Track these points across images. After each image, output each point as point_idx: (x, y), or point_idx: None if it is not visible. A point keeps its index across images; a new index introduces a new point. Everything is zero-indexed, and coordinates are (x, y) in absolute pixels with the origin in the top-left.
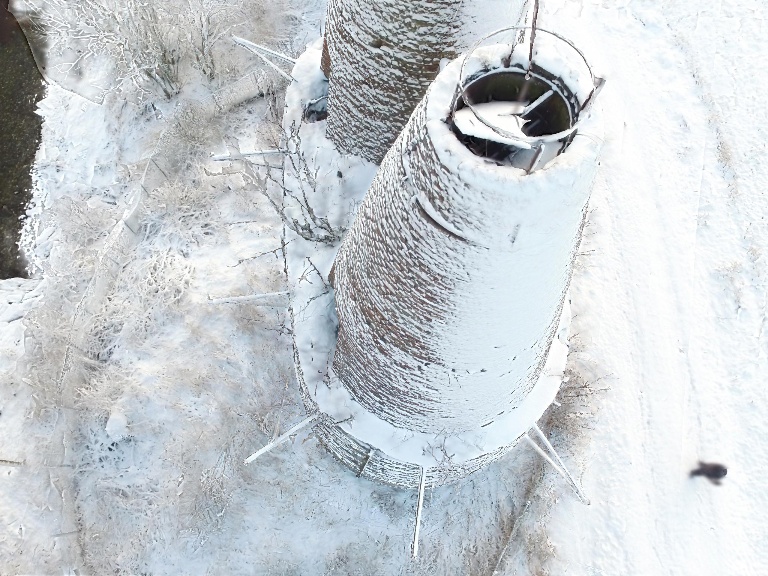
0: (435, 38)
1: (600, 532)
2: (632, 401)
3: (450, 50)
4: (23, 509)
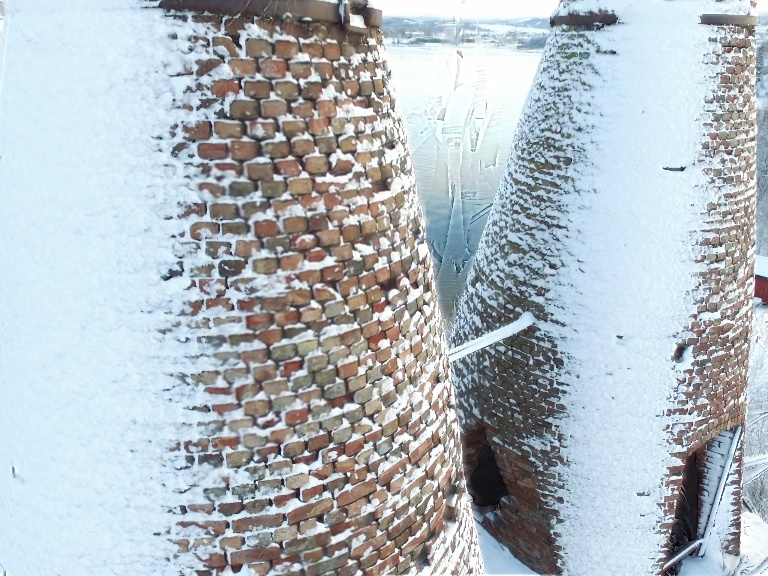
0: (524, 274)
1: None
2: None
3: (539, 302)
4: None
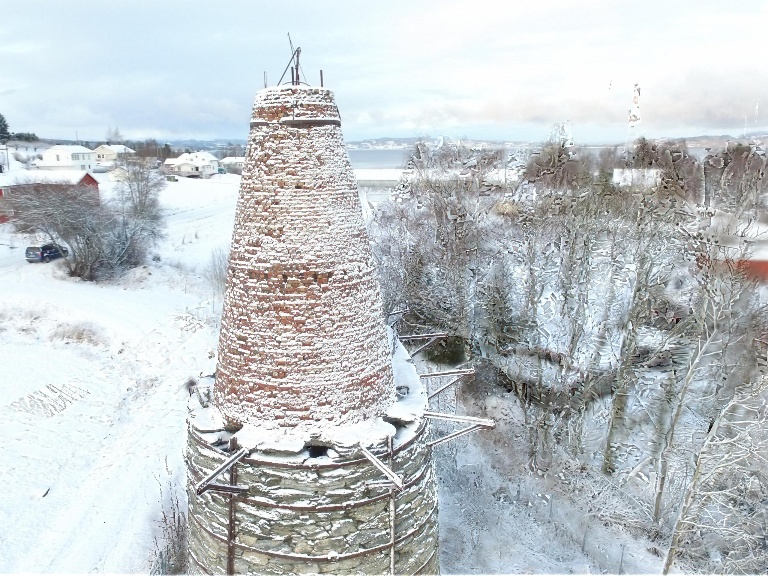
0: None
1: (181, 504)
2: (106, 573)
3: None
4: (641, 567)
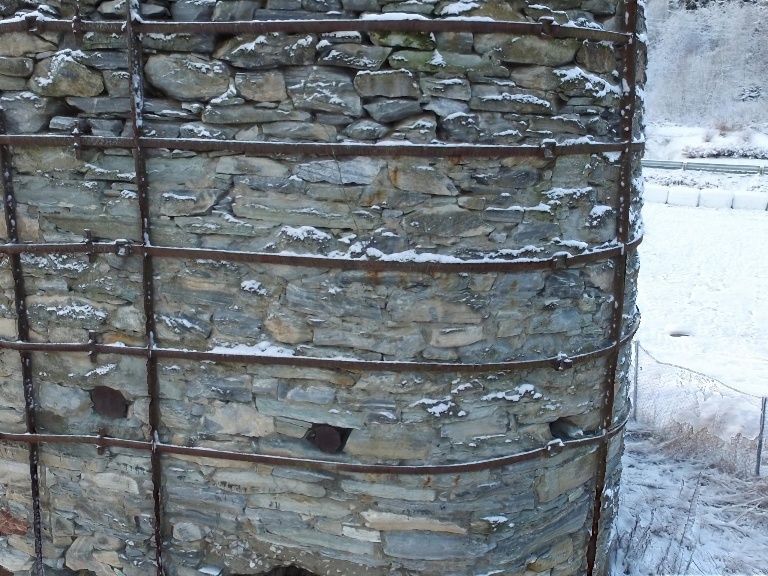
0: None
1: None
2: None
3: None
4: None
